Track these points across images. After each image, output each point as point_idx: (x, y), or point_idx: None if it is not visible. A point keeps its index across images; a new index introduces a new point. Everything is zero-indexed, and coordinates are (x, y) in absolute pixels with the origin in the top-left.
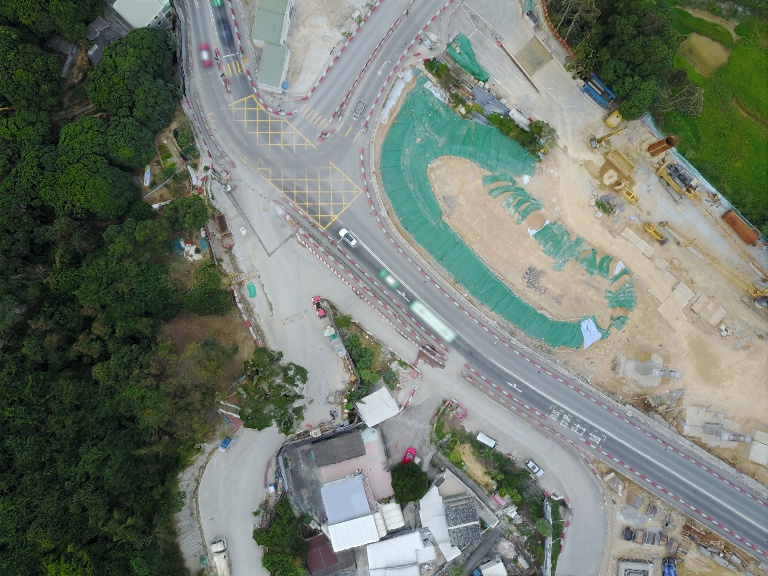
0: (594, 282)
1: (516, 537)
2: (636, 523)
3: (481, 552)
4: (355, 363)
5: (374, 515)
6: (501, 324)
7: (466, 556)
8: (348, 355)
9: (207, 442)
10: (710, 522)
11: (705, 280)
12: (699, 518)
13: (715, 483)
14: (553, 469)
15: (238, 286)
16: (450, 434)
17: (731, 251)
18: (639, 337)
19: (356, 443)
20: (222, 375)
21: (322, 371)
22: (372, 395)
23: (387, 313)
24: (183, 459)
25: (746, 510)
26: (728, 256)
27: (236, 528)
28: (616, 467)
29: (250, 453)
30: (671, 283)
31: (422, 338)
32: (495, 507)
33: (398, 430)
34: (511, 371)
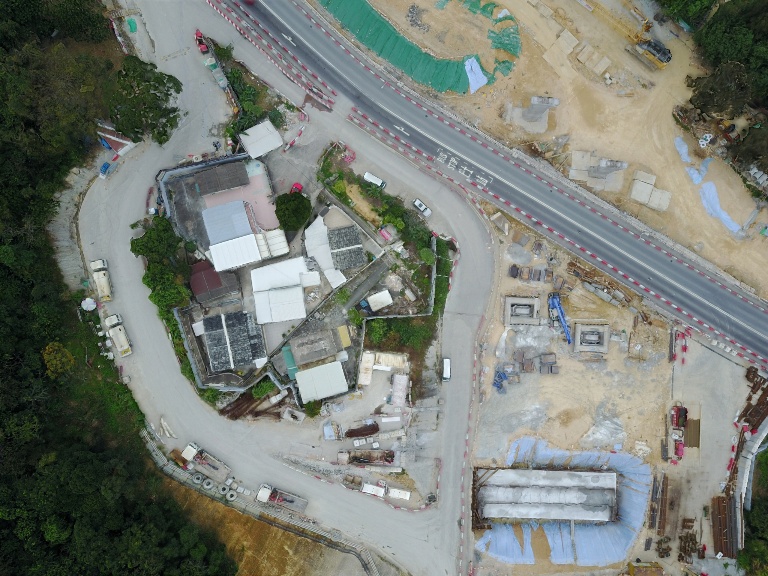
0: (477, 21)
1: (403, 271)
2: (523, 261)
3: (368, 284)
4: (237, 94)
5: (255, 235)
6: (388, 69)
7: (353, 288)
8: (230, 87)
9: (86, 168)
10: (594, 260)
11: (590, 30)
12: (584, 256)
13: (599, 222)
14: (441, 210)
15: (119, 23)
16: (337, 174)
17: (615, 1)
18: (525, 85)
19: (239, 172)
20: (91, 77)
21: (205, 104)
22: (255, 127)
23: (272, 54)
24: (58, 175)
25: (629, 248)
26: (612, 7)
27: (117, 252)
28: (503, 207)
29: (132, 181)
30: (556, 30)
31: (308, 80)
32: (382, 243)
33: (284, 168)
34: (398, 115)
